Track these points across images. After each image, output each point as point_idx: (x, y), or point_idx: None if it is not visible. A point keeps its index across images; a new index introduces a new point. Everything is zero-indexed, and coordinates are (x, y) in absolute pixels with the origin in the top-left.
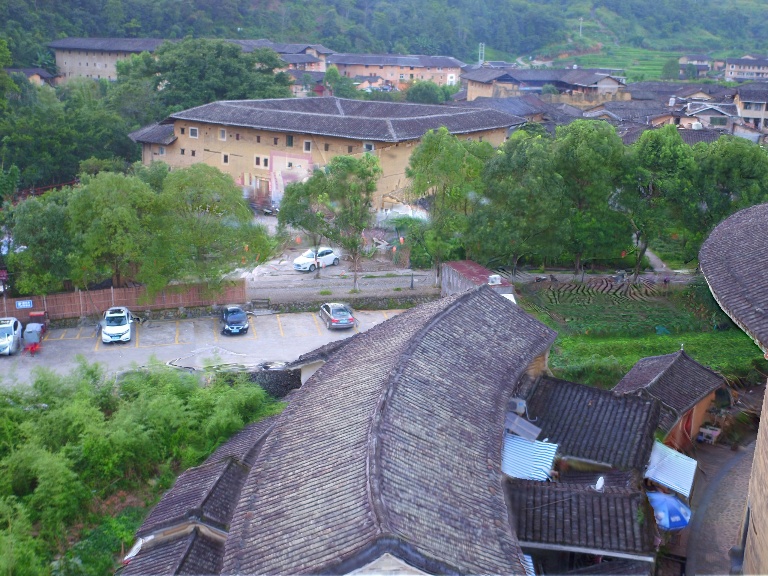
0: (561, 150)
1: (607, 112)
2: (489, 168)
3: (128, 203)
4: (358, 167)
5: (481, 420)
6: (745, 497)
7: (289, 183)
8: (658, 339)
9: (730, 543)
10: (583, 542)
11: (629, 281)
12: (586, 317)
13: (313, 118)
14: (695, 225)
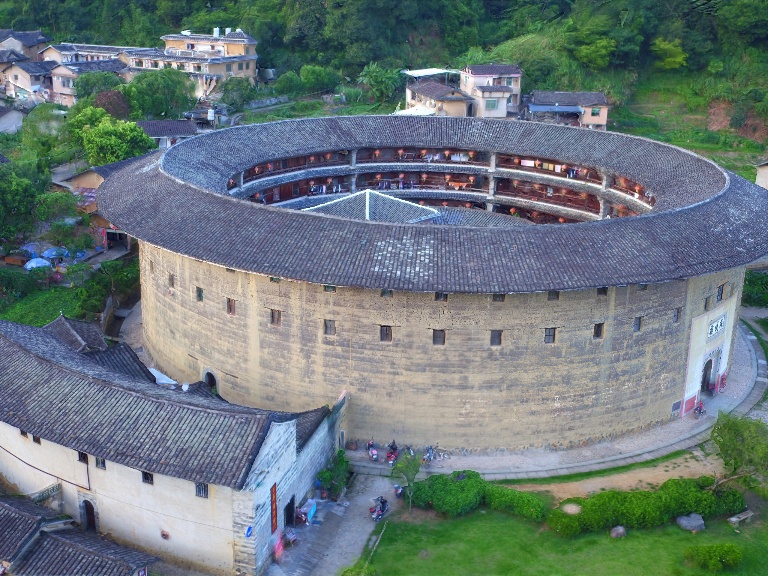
0: None
1: None
2: None
3: None
4: None
5: None
6: None
7: None
8: None
9: None
10: None
11: None
12: None
13: None
14: None
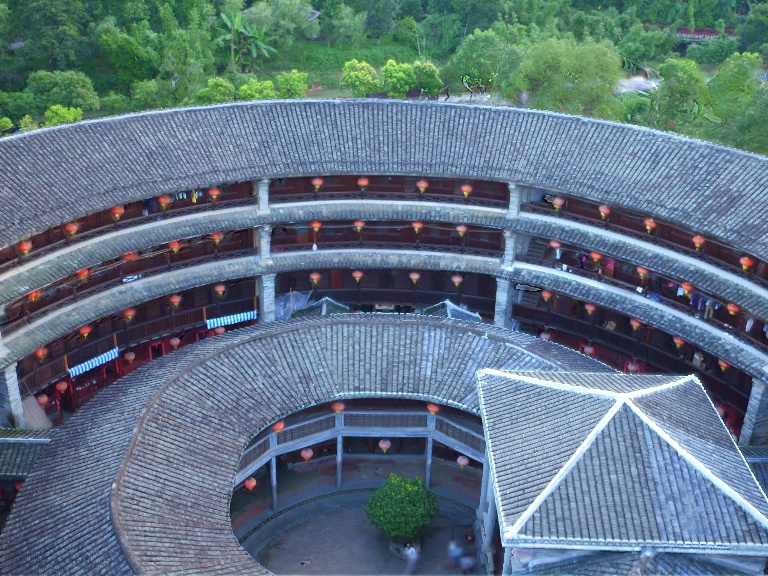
0: None
1: None
2: None
3: (542, 61)
4: (676, 71)
5: None
6: None
7: None
8: None
9: None
10: None
11: None
12: None
13: None
14: None
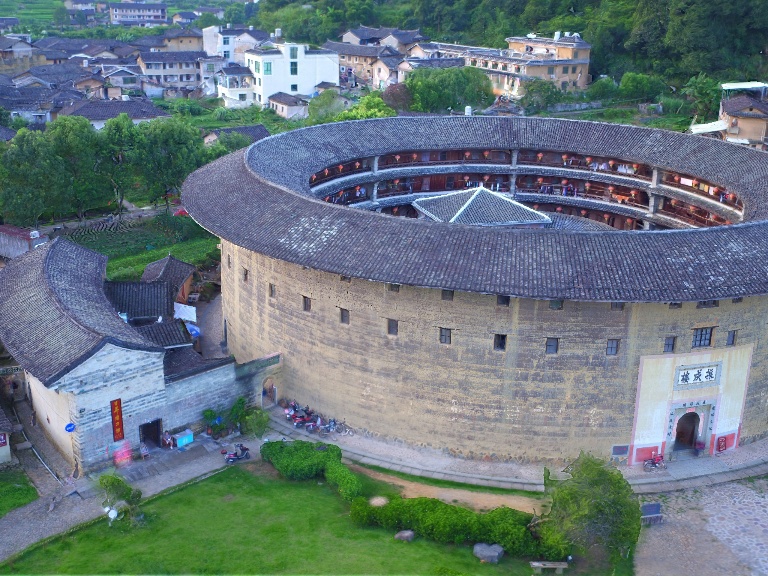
0: (56, 139)
1: (36, 79)
2: (7, 157)
3: None
4: None
5: (99, 301)
6: (220, 321)
7: None
8: (150, 253)
9: (219, 341)
10: (161, 345)
11: (118, 220)
12: (100, 248)
13: None
14: (153, 178)
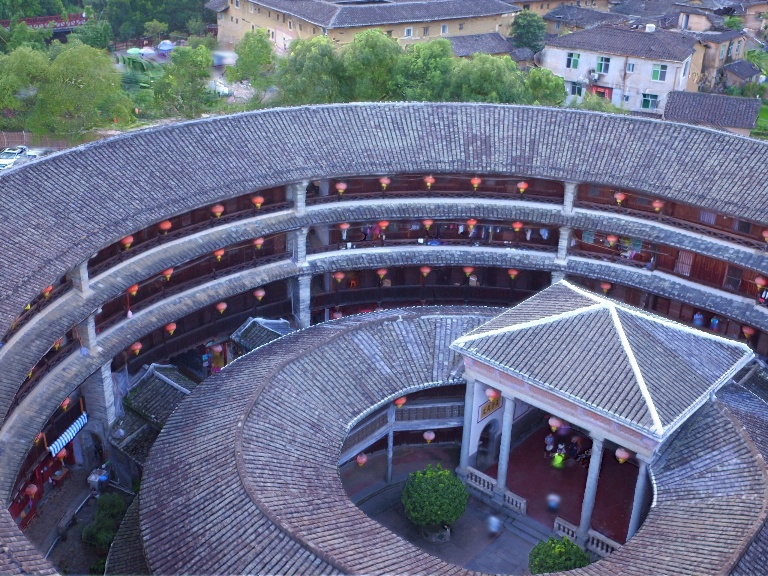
0: (342, 55)
1: None
2: None
3: (24, 72)
4: (191, 57)
5: None
6: None
7: (166, 64)
8: None
9: None
10: None
11: None
12: None
13: (299, 0)
14: None
